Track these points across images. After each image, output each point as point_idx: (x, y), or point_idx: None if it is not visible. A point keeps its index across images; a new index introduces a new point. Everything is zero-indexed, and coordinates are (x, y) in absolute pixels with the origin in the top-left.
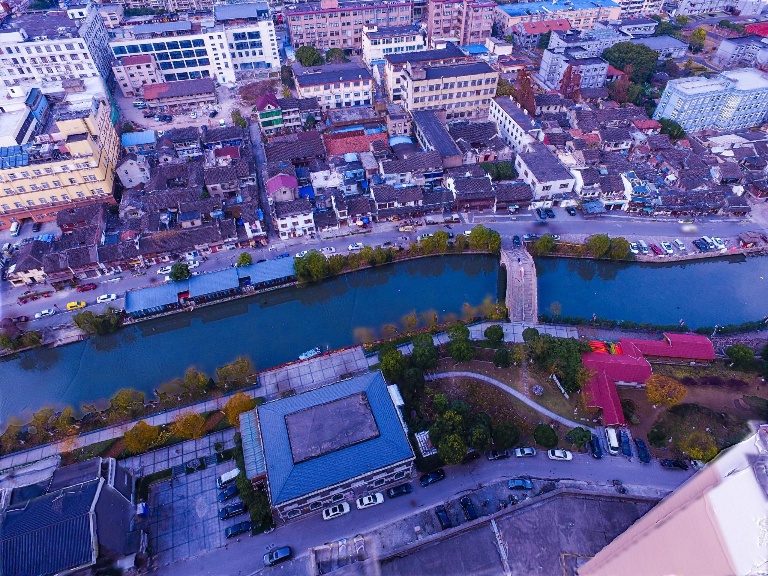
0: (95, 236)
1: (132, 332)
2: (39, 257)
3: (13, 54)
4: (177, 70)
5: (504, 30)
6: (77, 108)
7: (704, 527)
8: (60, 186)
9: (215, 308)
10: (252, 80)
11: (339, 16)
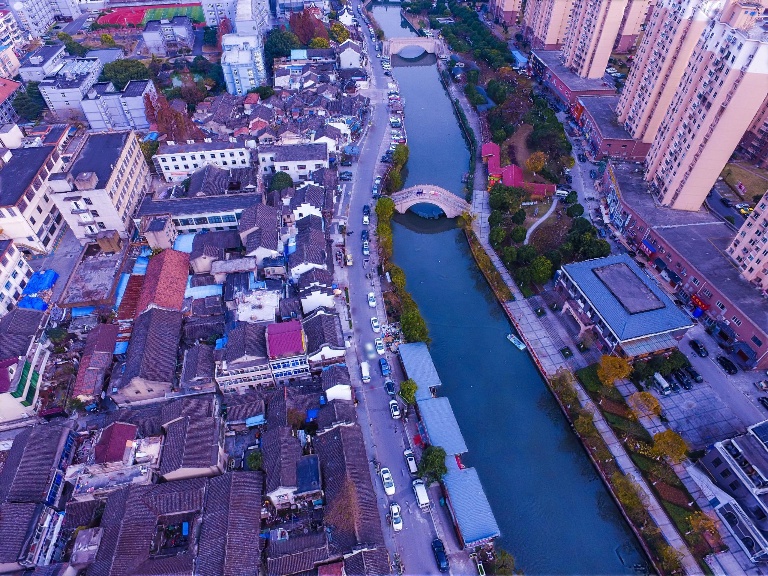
0: None
1: None
2: None
3: None
4: None
5: None
6: None
7: (755, 79)
8: None
9: None
10: None
11: None
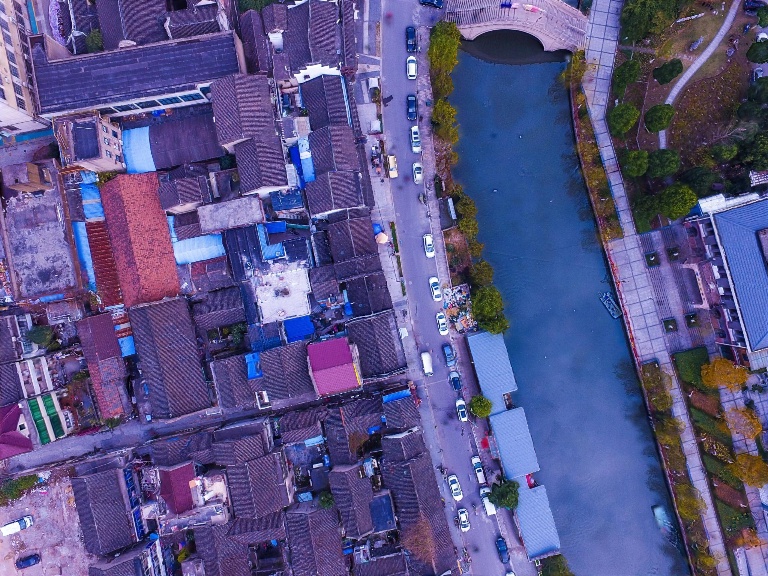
0: None
1: None
2: None
3: None
4: None
5: None
6: None
7: None
8: None
9: None
10: None
11: None
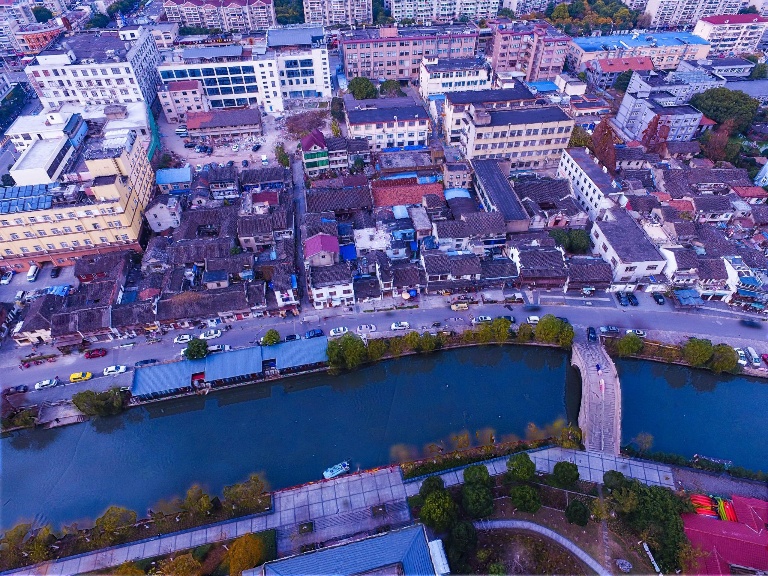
0: (111, 294)
1: (138, 412)
2: (48, 315)
3: (59, 76)
4: (224, 96)
5: (576, 65)
6: (110, 144)
7: None
8: (83, 231)
9: (233, 391)
10: (300, 110)
11: (398, 45)
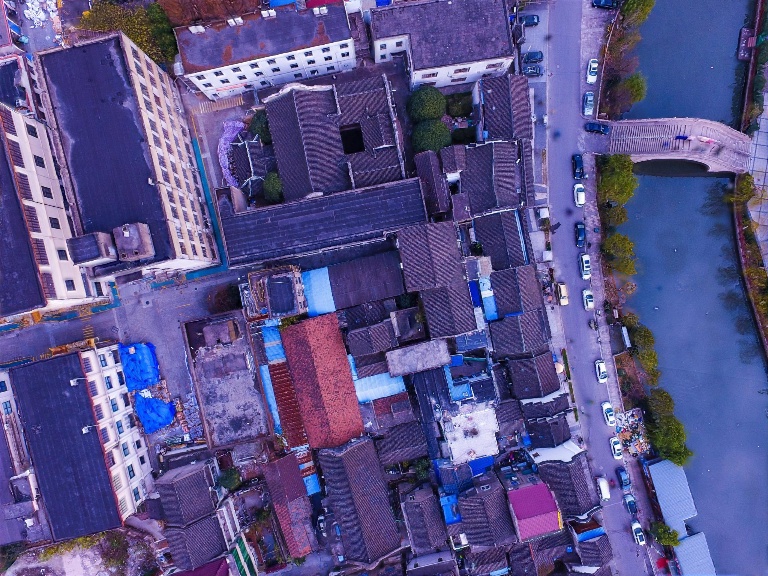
0: None
1: None
2: None
3: None
4: None
5: None
6: None
7: None
8: None
9: None
10: None
11: None
